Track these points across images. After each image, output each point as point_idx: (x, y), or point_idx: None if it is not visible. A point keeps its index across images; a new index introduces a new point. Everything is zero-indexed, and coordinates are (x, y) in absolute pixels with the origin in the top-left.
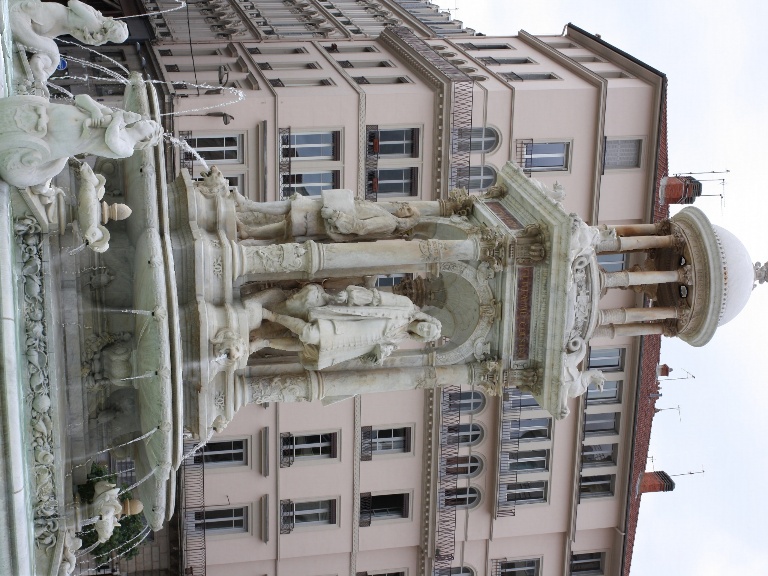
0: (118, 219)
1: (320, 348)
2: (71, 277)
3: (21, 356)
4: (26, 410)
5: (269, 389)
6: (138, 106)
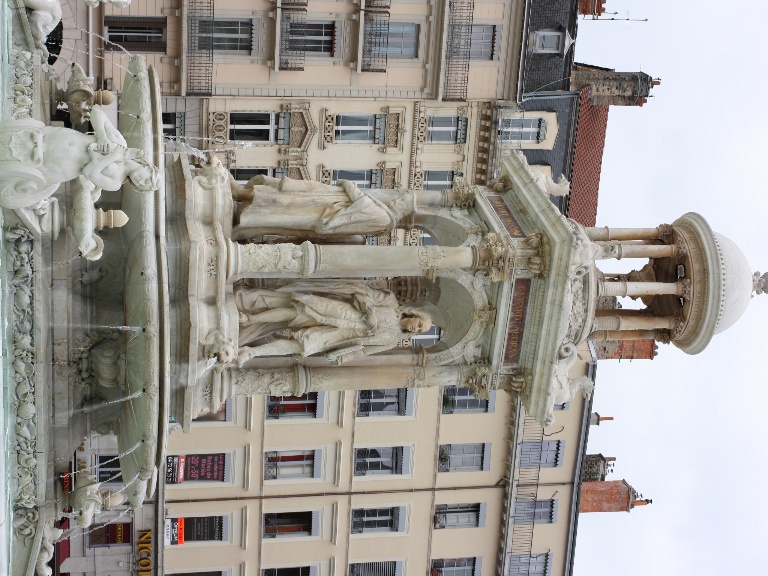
0: None
1: None
2: None
3: None
4: None
5: None
6: (144, 464)
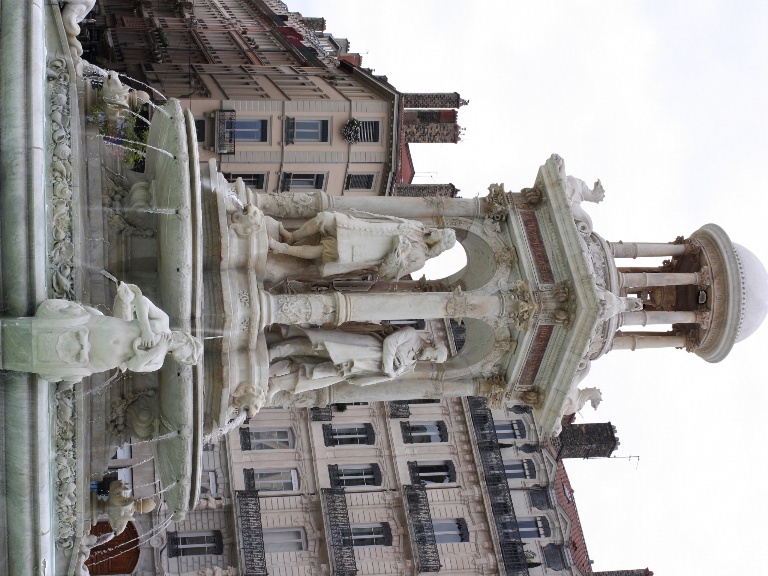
0: (137, 100)
1: (336, 223)
2: (95, 157)
3: (46, 117)
4: (47, 156)
5: (294, 298)
6: None
